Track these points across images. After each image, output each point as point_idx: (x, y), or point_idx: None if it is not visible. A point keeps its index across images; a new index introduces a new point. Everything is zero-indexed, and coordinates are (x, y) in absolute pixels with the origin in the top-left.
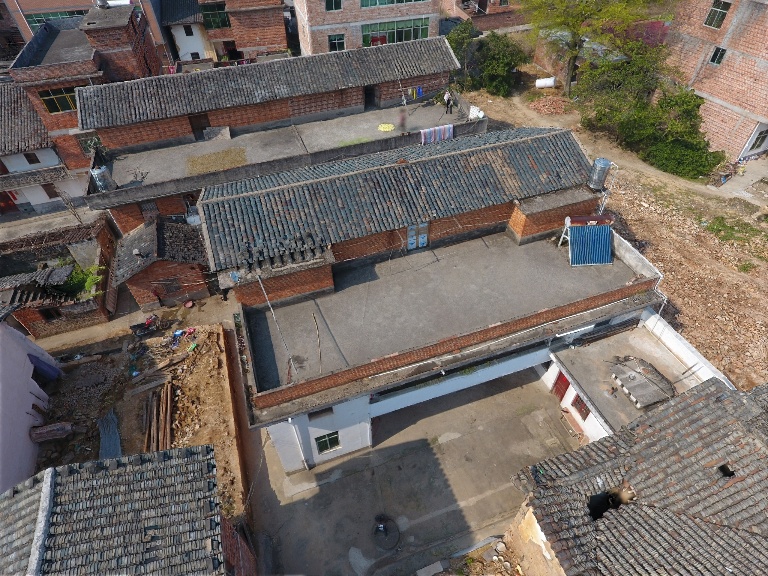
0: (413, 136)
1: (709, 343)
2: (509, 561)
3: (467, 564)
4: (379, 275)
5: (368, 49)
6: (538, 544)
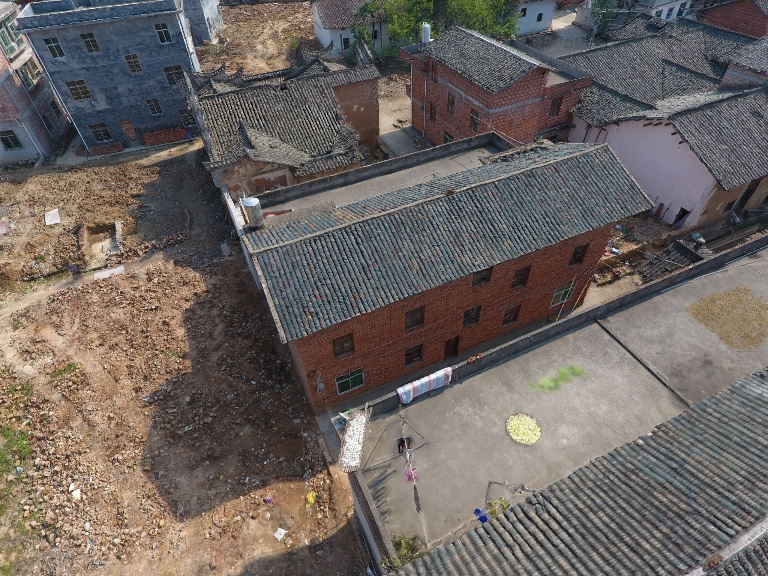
0: None
1: None
2: None
3: None
4: None
5: (684, 569)
6: None
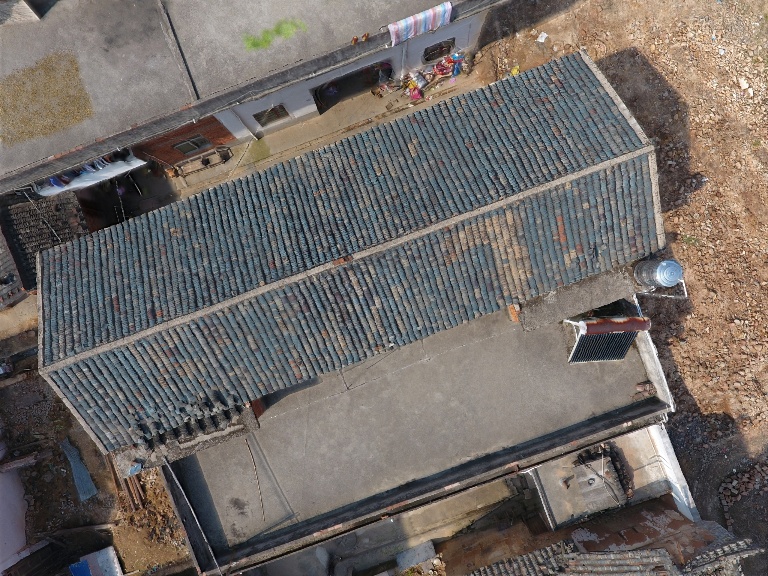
0: (374, 38)
1: (707, 357)
2: (442, 574)
3: (408, 574)
4: (322, 376)
5: None
6: None
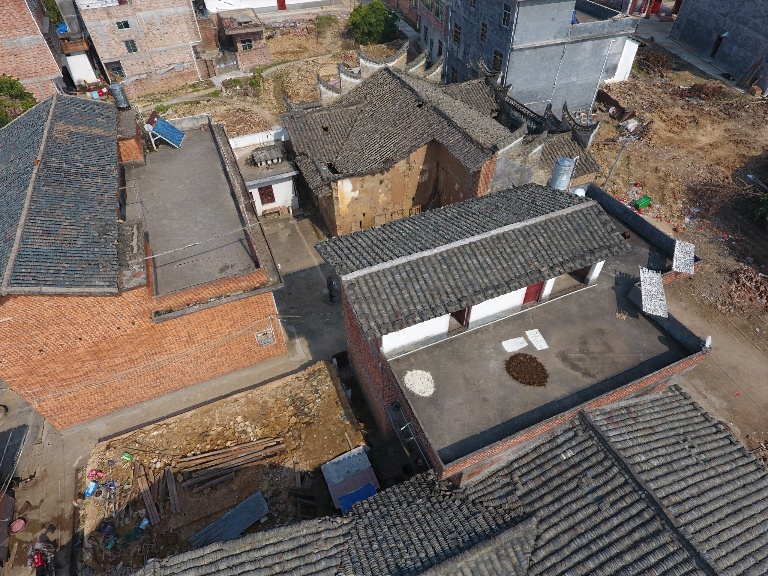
0: None
1: None
2: None
3: None
4: None
5: None
6: (351, 198)
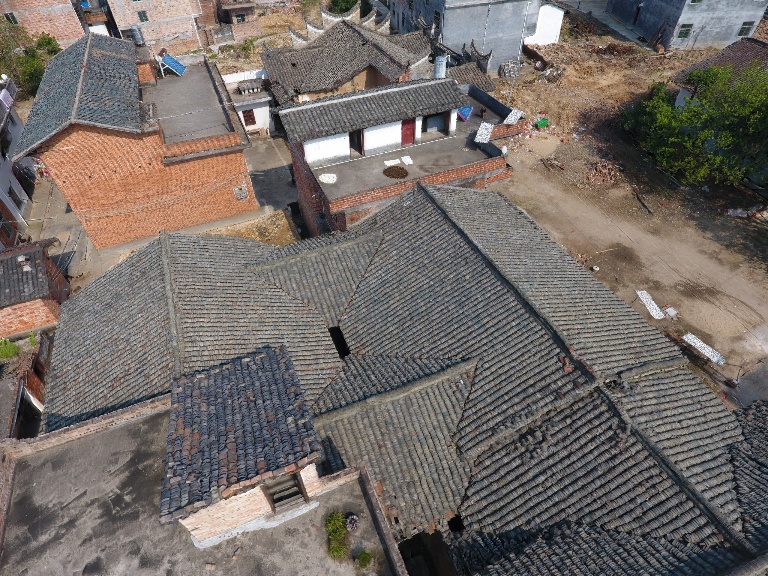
0: (1, 104)
1: None
2: None
3: None
4: None
5: None
6: None
